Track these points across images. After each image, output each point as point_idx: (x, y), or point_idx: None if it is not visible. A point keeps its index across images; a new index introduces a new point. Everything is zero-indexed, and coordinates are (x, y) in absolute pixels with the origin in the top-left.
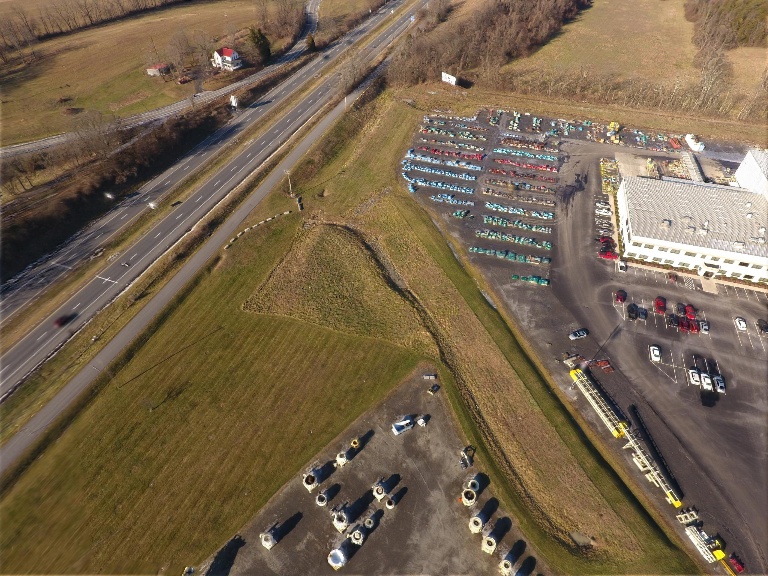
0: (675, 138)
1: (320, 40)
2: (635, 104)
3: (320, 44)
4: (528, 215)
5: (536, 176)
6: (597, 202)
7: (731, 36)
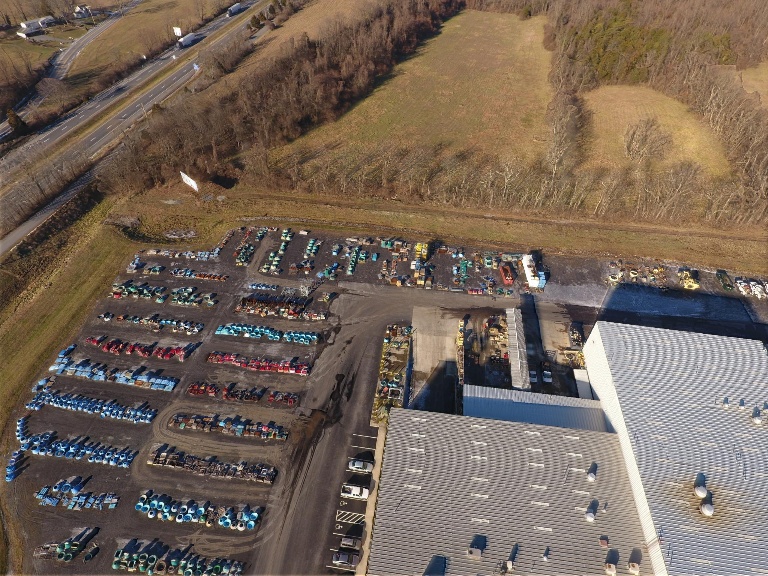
0: (509, 261)
1: (39, 114)
2: (459, 200)
3: (39, 120)
4: (210, 524)
5: (266, 392)
6: (352, 458)
7: (589, 76)
